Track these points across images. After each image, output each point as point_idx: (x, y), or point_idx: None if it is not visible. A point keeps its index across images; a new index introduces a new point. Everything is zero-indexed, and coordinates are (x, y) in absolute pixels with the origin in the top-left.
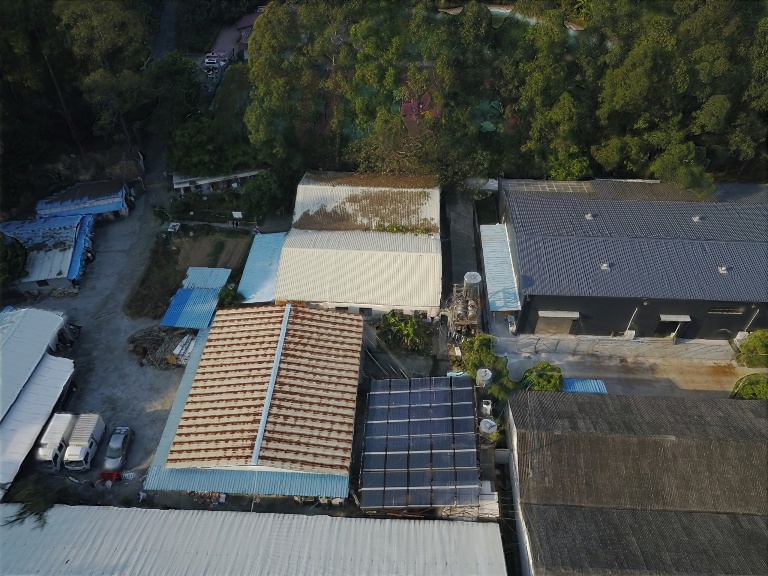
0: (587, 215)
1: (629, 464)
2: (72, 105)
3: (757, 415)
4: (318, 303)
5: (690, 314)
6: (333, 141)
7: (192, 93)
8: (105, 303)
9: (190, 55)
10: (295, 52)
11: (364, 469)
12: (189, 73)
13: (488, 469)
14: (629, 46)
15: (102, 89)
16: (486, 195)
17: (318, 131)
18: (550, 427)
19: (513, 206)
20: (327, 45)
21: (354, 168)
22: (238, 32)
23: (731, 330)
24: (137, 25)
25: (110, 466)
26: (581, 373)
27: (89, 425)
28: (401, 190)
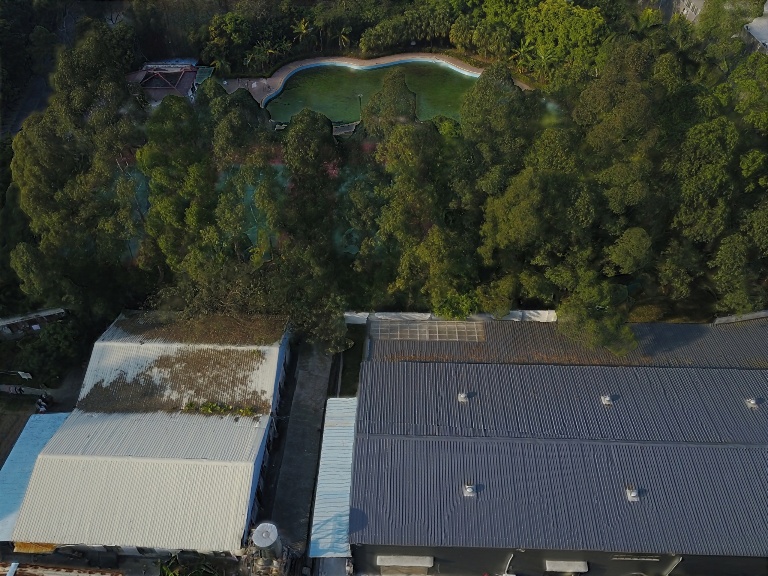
0: (460, 396)
1: None
2: None
3: None
4: None
5: (588, 560)
6: (155, 273)
7: None
8: None
9: None
10: (70, 179)
11: None
12: None
13: None
14: (517, 163)
15: None
16: (346, 346)
17: (127, 267)
18: None
19: (366, 379)
20: (105, 173)
21: None
22: None
23: (648, 573)
24: None
25: None
26: None
27: None
28: (229, 348)
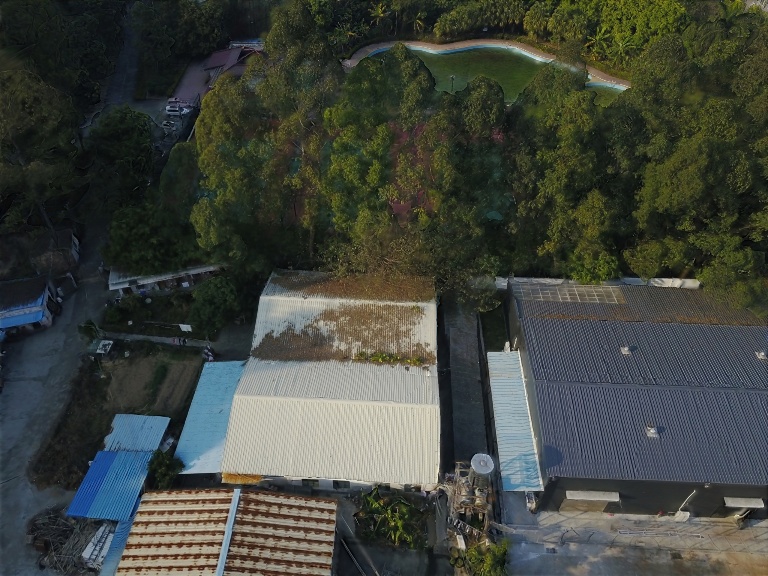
0: (623, 349)
1: None
2: None
3: None
4: None
5: (763, 497)
6: (306, 234)
7: (141, 160)
8: (6, 462)
9: (151, 99)
10: (254, 137)
11: None
12: (141, 132)
13: None
14: (674, 132)
15: (1, 189)
16: (493, 306)
17: (286, 226)
18: None
19: (529, 333)
20: (294, 132)
21: (332, 265)
22: (206, 73)
23: None
24: (52, 101)
25: None
26: None
27: None
28: (389, 304)
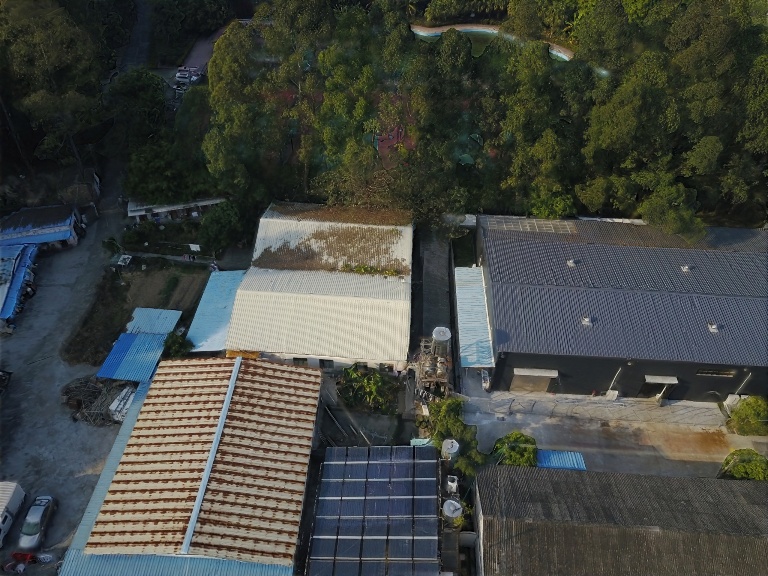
0: (569, 261)
1: (608, 560)
2: (21, 123)
3: (749, 500)
4: (274, 353)
5: (677, 375)
6: (301, 170)
7: (155, 112)
8: (41, 346)
9: (162, 68)
10: (259, 77)
11: (311, 556)
12: (155, 89)
13: (451, 557)
14: (617, 81)
15: (44, 112)
16: (463, 233)
17: (284, 160)
18: (521, 513)
19: (490, 249)
20: (293, 71)
21: (323, 199)
22: None
23: (721, 392)
24: (87, 42)
25: (25, 544)
26: (558, 438)
27: (4, 496)
28: (371, 227)
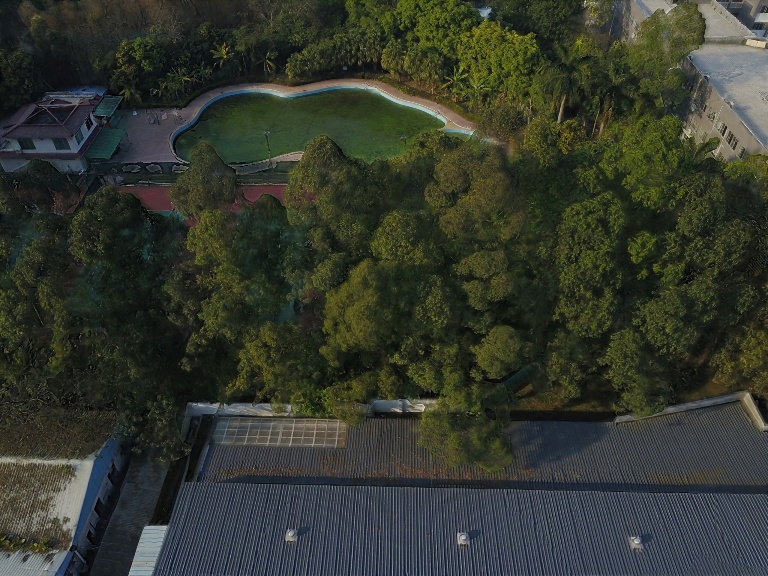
0: (287, 534)
1: None
2: None
3: None
4: None
5: None
6: None
7: None
8: None
9: None
10: None
11: None
12: None
13: None
14: (364, 249)
15: None
16: (182, 454)
17: None
18: None
19: (181, 508)
20: None
21: None
22: None
23: None
24: None
25: None
26: None
27: None
28: (34, 462)
